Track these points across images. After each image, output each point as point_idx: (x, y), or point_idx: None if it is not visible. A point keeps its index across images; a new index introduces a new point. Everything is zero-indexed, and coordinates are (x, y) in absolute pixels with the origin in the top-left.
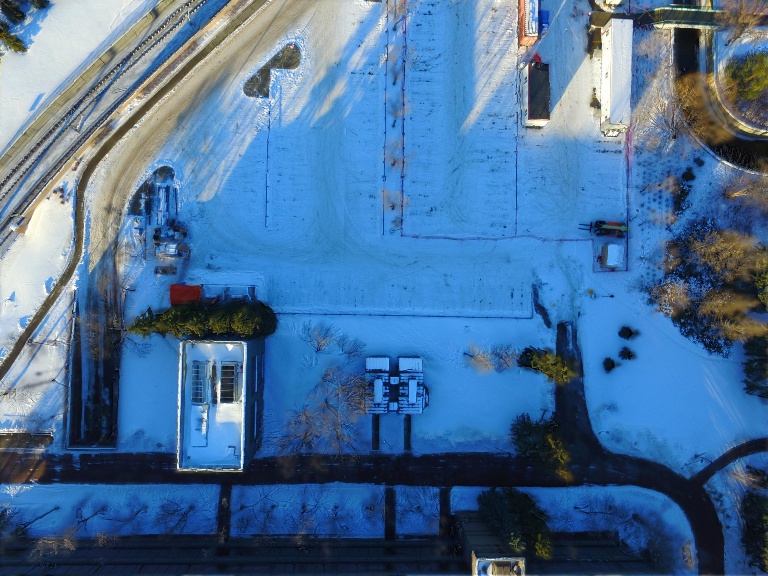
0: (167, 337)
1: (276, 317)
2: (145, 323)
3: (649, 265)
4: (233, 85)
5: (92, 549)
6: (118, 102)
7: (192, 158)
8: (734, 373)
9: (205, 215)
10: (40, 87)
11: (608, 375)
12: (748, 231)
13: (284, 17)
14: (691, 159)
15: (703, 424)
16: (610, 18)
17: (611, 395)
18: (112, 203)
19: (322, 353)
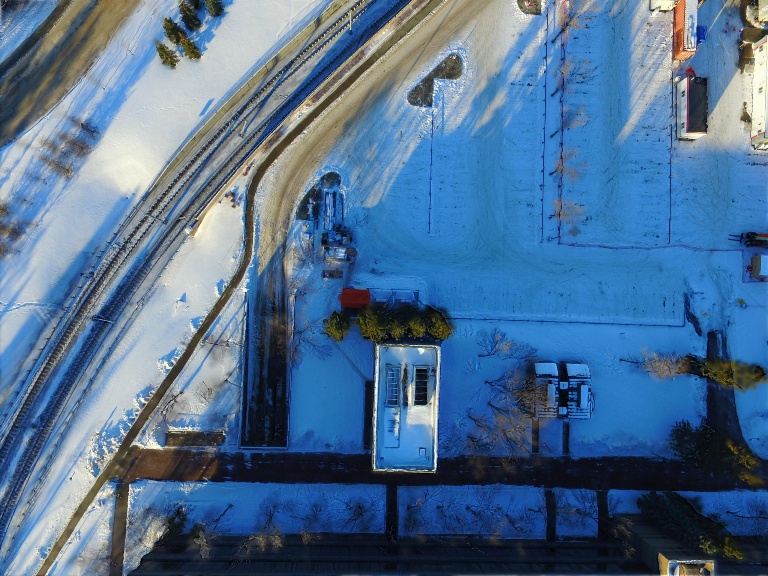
0: None
1: None
2: (339, 326)
3: None
4: (398, 94)
5: (273, 546)
6: (280, 108)
7: (358, 165)
8: None
9: (370, 221)
10: (210, 93)
11: (758, 383)
12: None
13: (446, 28)
14: None
15: None
16: (764, 34)
17: (762, 403)
18: (281, 207)
19: (489, 358)
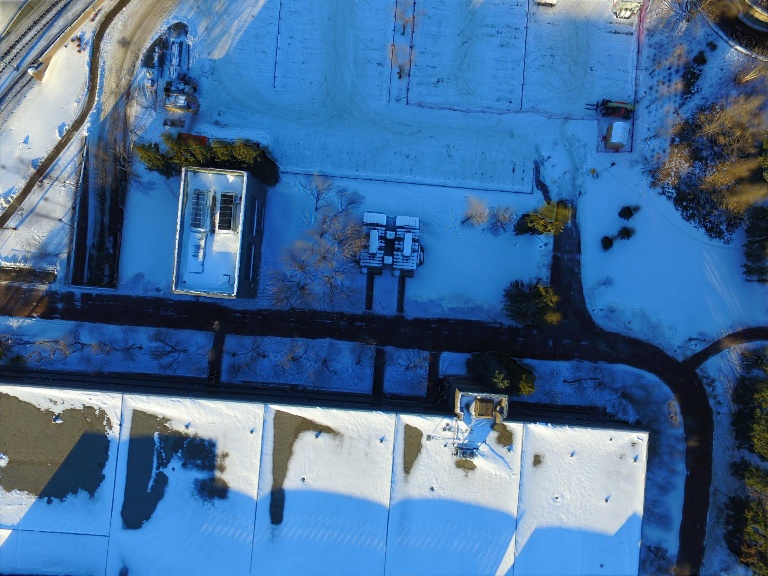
0: (172, 186)
1: (278, 171)
2: (150, 151)
3: (654, 147)
4: None
5: (87, 376)
6: None
7: (206, 16)
8: (734, 260)
9: (215, 72)
10: None
11: (606, 254)
12: (757, 119)
13: None
14: (703, 43)
15: (699, 309)
16: None
17: (607, 272)
18: (126, 55)
19: (321, 208)
